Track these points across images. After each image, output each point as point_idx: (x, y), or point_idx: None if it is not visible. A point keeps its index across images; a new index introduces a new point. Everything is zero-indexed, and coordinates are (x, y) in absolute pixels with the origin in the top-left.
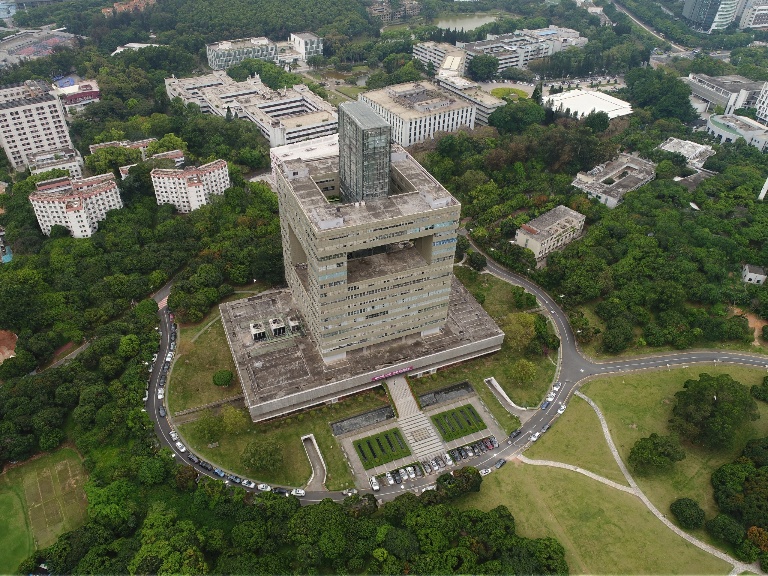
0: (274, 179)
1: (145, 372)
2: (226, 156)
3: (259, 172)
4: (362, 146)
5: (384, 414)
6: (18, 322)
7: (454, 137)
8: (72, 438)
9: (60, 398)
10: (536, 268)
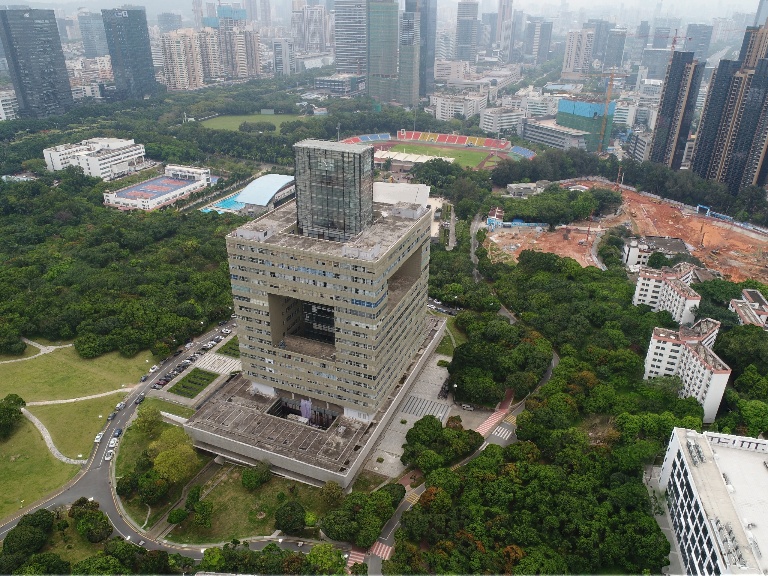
0: None
1: None
2: None
3: None
4: None
5: None
6: None
7: None
8: None
9: None
10: None
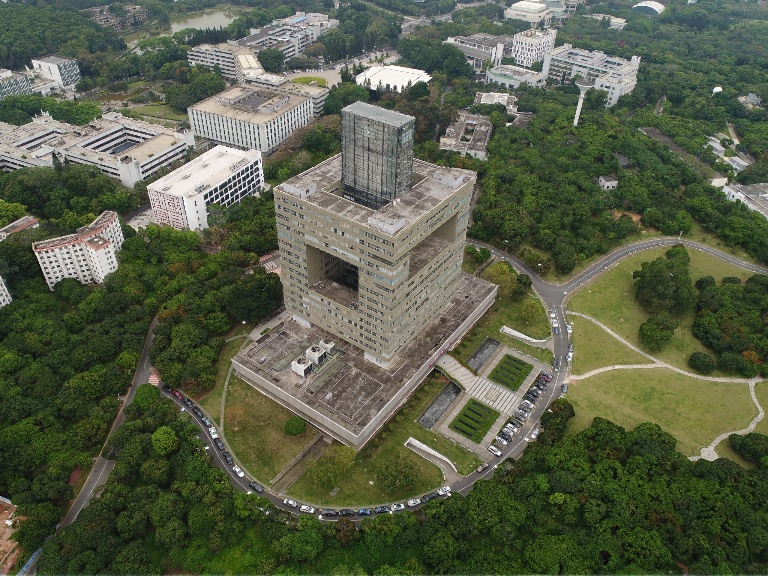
0: (158, 219)
1: (210, 458)
2: (86, 209)
3: (127, 217)
4: (397, 144)
5: (451, 393)
6: (2, 476)
7: (317, 131)
8: (175, 565)
9: (128, 531)
10: None
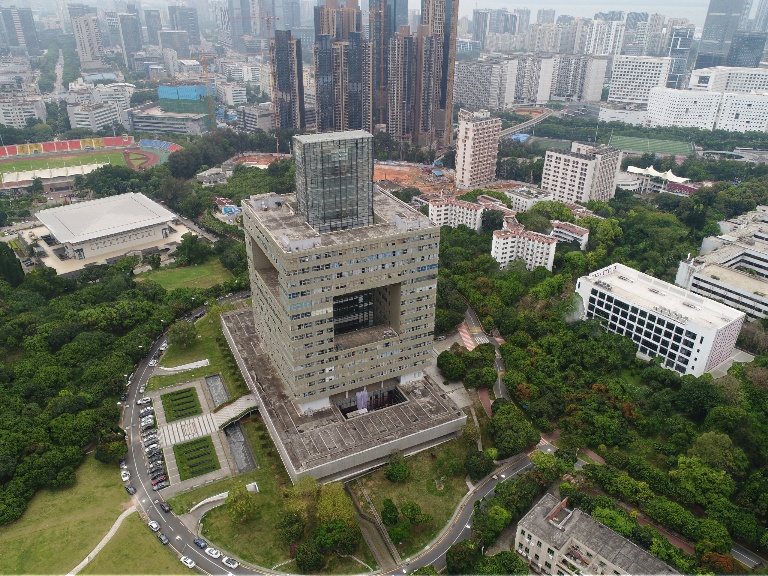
0: None
1: None
2: None
3: None
4: None
5: None
6: None
7: None
8: None
9: None
10: (492, 550)
